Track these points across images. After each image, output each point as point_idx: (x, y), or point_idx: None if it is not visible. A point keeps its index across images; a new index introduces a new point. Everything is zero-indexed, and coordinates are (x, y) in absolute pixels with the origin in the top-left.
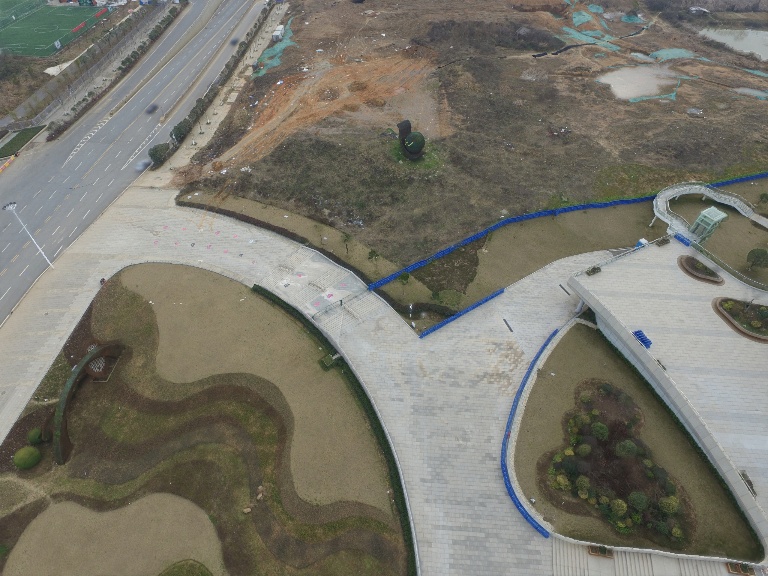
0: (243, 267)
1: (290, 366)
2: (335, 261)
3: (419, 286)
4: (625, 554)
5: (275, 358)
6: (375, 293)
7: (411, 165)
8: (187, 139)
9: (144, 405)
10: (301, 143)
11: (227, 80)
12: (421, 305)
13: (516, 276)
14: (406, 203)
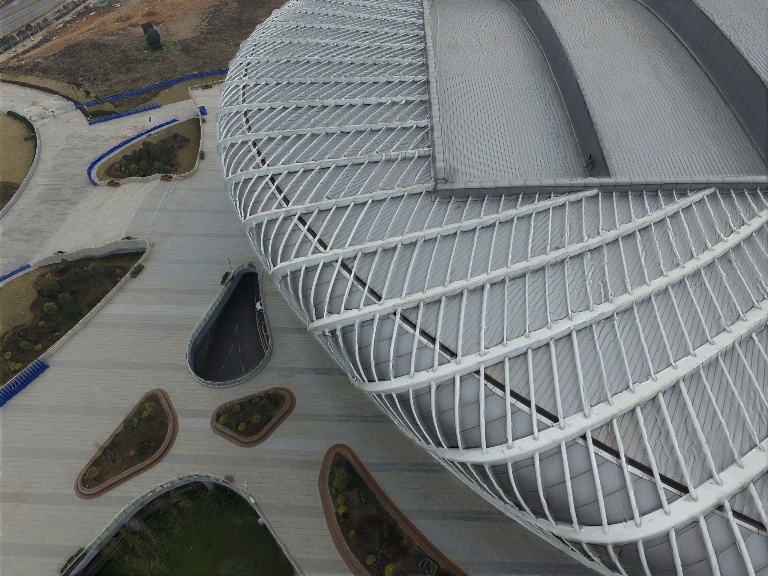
0: (9, 106)
1: (7, 140)
2: (67, 99)
3: (108, 105)
4: (124, 184)
5: (0, 138)
6: (78, 109)
7: (151, 52)
8: (11, 49)
9: None
10: (84, 44)
11: (62, 17)
12: (99, 111)
13: (176, 101)
14: (134, 72)
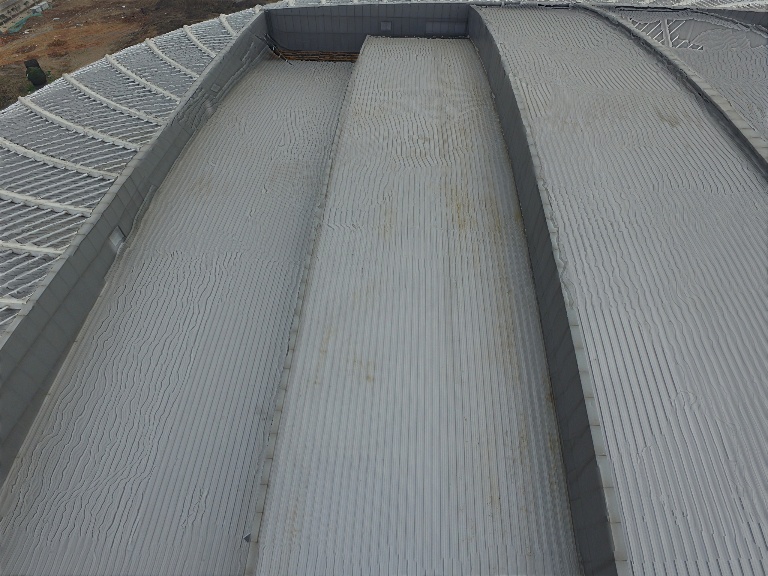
0: None
1: None
2: None
3: None
4: None
5: None
6: None
7: None
8: None
9: None
10: None
11: None
12: None
13: None
14: None
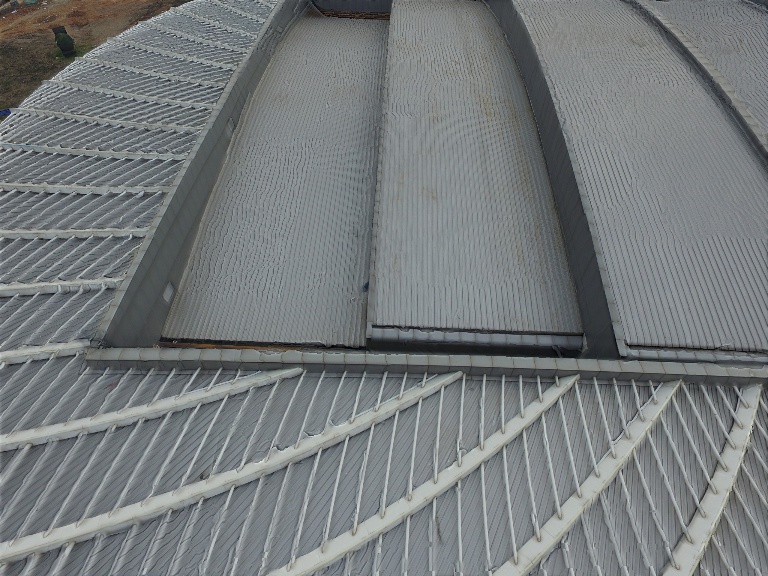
0: None
1: None
2: None
3: None
4: None
5: None
6: None
7: (63, 59)
8: None
9: None
10: None
11: None
12: None
13: None
14: (39, 81)
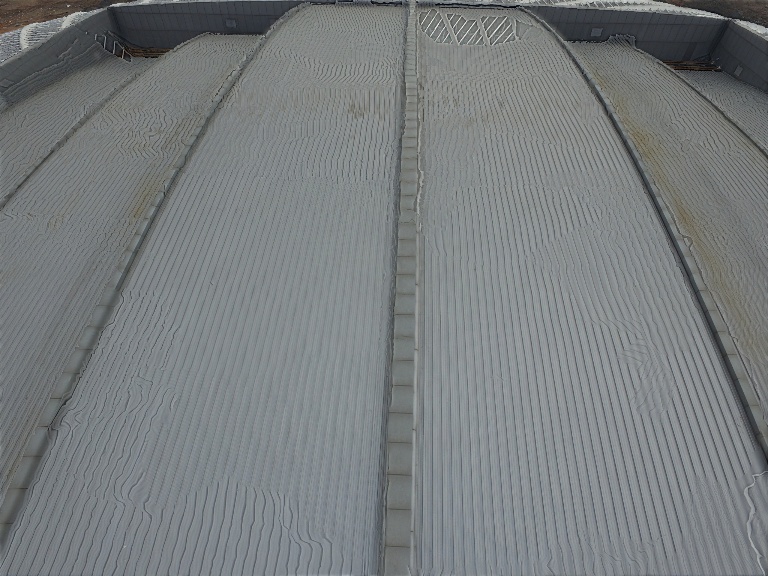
0: None
1: None
2: None
3: None
4: None
5: None
6: None
7: None
8: None
9: None
10: None
11: None
12: None
13: None
14: None
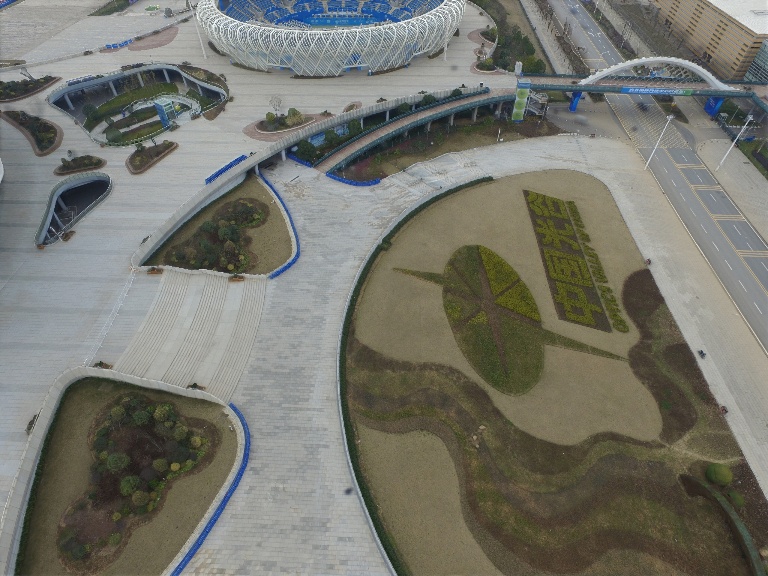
0: None
1: None
2: None
3: None
4: None
5: None
6: None
7: None
8: None
9: (650, 545)
10: None
11: None
12: None
13: None
14: None
